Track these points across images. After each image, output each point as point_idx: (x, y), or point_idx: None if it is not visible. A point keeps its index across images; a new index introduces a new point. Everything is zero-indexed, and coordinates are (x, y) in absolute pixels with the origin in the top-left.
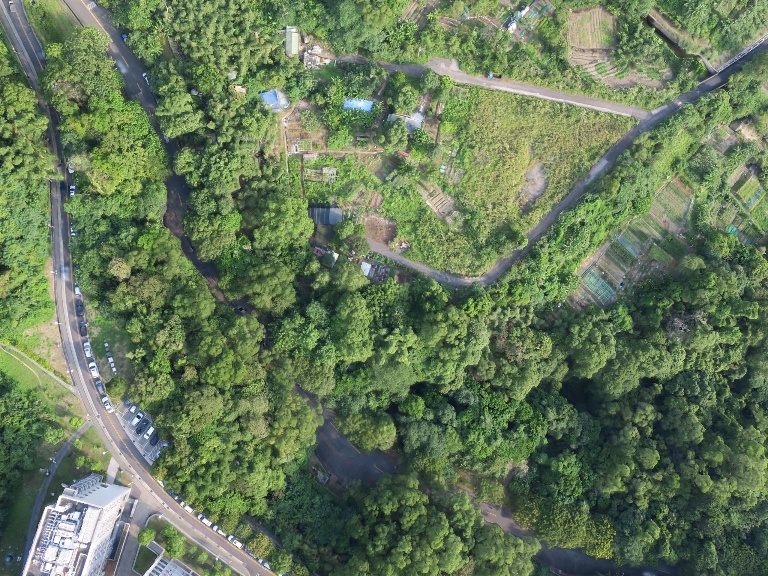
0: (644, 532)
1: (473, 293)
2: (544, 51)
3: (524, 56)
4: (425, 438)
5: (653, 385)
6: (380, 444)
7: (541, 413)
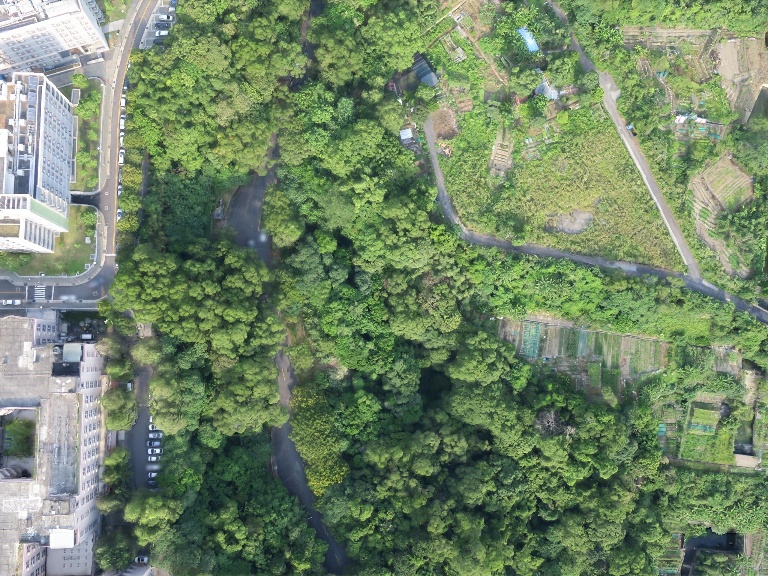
0: (358, 504)
1: (450, 228)
2: (682, 157)
3: (666, 142)
4: (307, 266)
5: (485, 440)
6: (277, 235)
7: (394, 358)
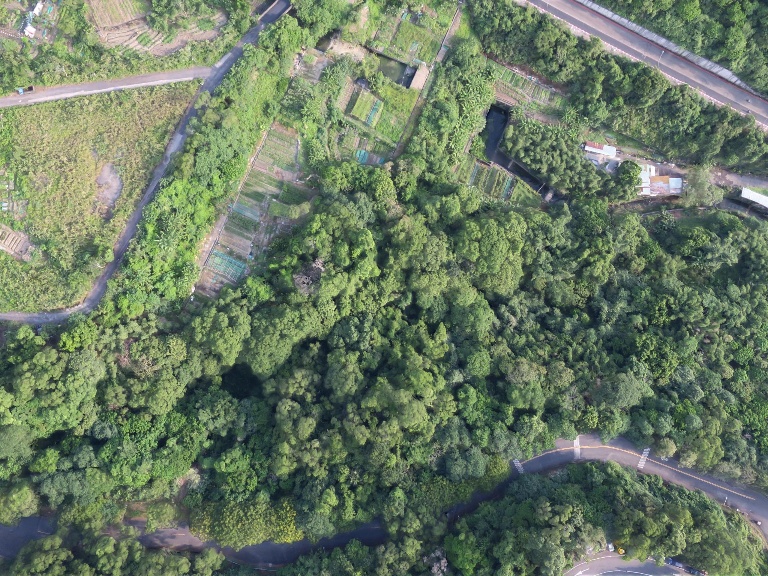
0: (319, 504)
1: None
2: (73, 44)
3: (50, 58)
4: (64, 490)
5: (309, 346)
6: (22, 512)
7: (195, 417)
